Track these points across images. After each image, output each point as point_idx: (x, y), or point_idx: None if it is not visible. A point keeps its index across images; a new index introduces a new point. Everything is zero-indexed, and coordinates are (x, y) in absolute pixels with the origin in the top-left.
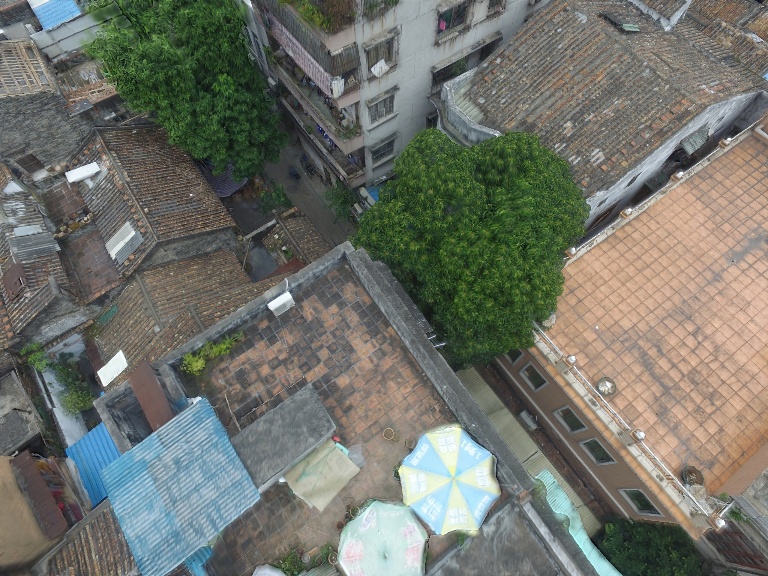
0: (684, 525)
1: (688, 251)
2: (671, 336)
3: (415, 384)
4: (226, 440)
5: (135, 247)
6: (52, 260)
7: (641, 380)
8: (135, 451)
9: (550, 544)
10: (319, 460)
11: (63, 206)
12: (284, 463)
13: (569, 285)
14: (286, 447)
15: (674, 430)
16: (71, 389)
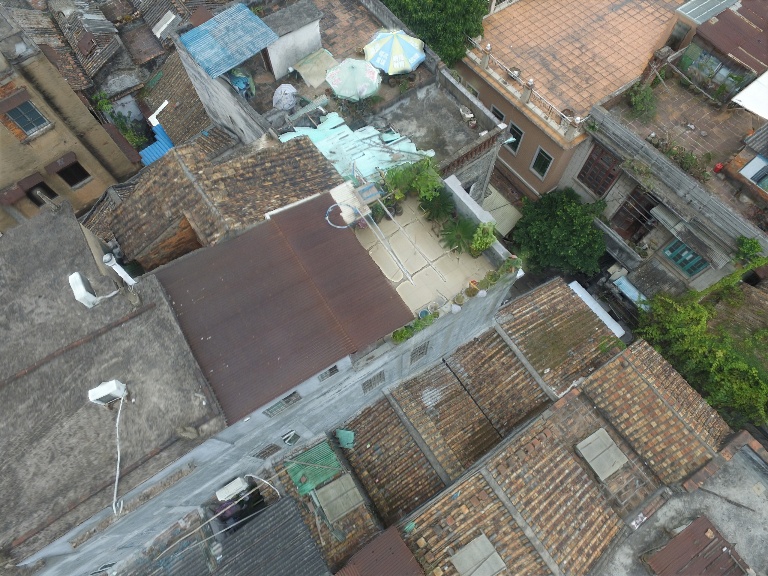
0: (560, 142)
1: (581, 5)
2: (563, 50)
3: (377, 31)
4: (256, 17)
5: (176, 25)
6: (113, 36)
7: (539, 72)
8: (200, 26)
9: (456, 85)
10: (314, 57)
11: (116, 13)
12: (292, 28)
13: (494, 24)
14: (293, 22)
15: (559, 96)
16: (129, 130)
